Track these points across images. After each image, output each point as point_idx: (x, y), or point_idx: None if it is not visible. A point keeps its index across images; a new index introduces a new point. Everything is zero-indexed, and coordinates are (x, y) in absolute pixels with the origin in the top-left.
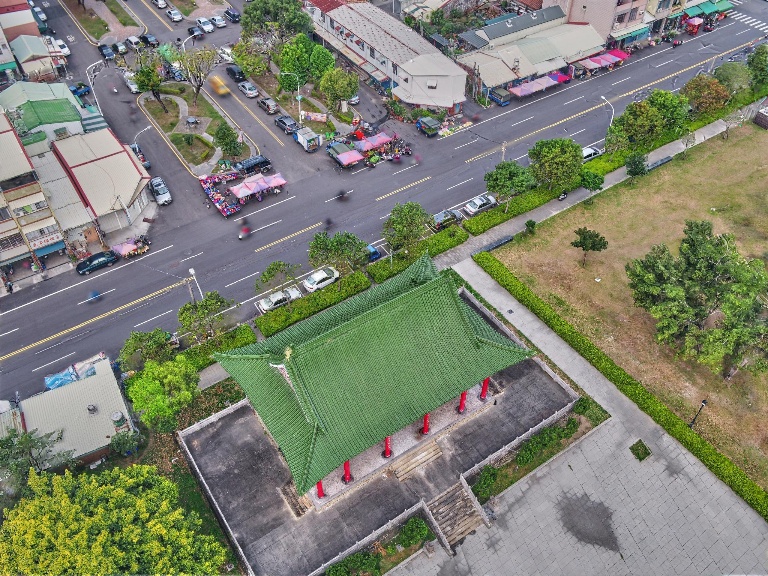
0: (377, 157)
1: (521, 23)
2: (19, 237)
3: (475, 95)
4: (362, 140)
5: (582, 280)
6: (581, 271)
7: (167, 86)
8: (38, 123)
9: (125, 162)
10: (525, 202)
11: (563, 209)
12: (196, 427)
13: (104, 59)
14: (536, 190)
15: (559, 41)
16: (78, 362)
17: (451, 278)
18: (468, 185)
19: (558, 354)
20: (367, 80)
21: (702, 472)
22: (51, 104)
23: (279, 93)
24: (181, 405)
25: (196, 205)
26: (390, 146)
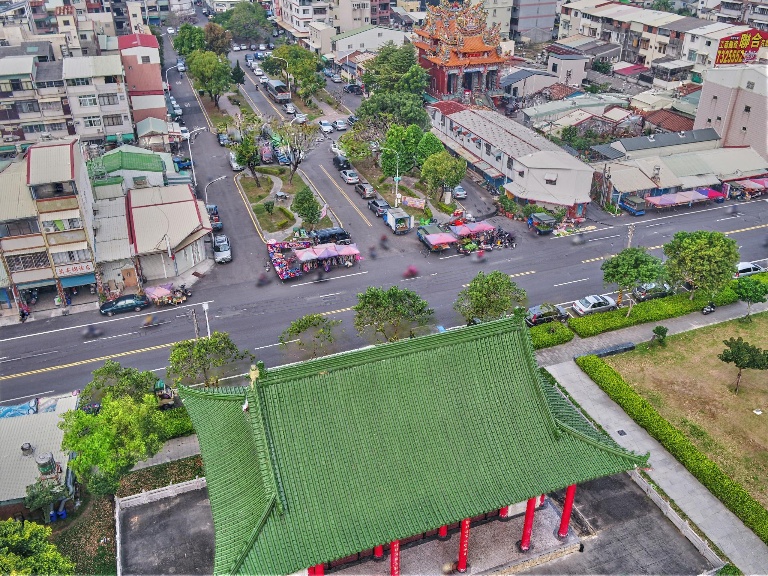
0: (474, 245)
1: (666, 139)
2: (45, 257)
3: (603, 202)
4: (459, 225)
5: (733, 409)
6: (732, 398)
7: (269, 168)
8: (118, 167)
9: (189, 209)
10: (655, 308)
11: (708, 324)
12: (143, 498)
13: (207, 126)
14: (672, 298)
15: (711, 159)
16: (46, 397)
17: None
18: (582, 284)
19: (691, 501)
20: (480, 181)
21: None
22: (141, 156)
23: (381, 182)
24: (130, 460)
25: (255, 267)
26: (492, 236)
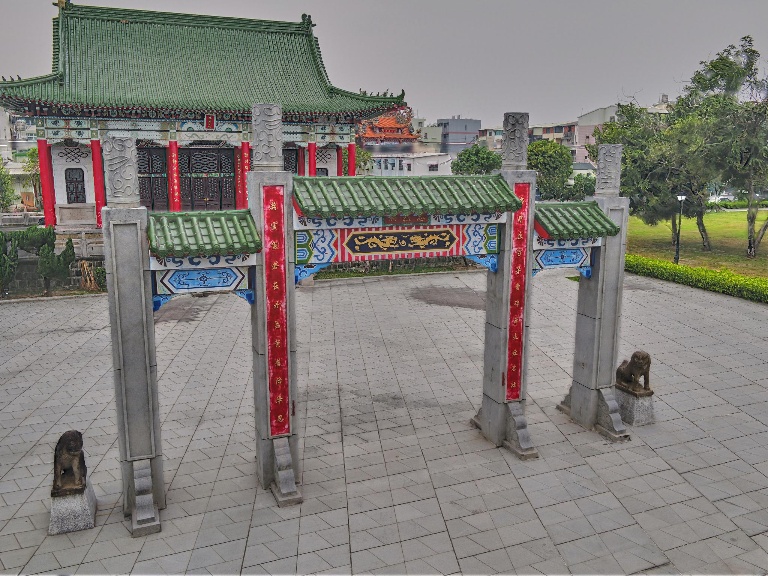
0: None
1: None
2: None
3: None
4: None
5: None
6: None
7: None
8: None
9: None
10: None
11: None
12: None
13: None
14: None
15: None
16: None
17: (311, 30)
18: None
19: None
20: None
21: (689, 290)
22: None
23: None
24: None
25: None
26: None
